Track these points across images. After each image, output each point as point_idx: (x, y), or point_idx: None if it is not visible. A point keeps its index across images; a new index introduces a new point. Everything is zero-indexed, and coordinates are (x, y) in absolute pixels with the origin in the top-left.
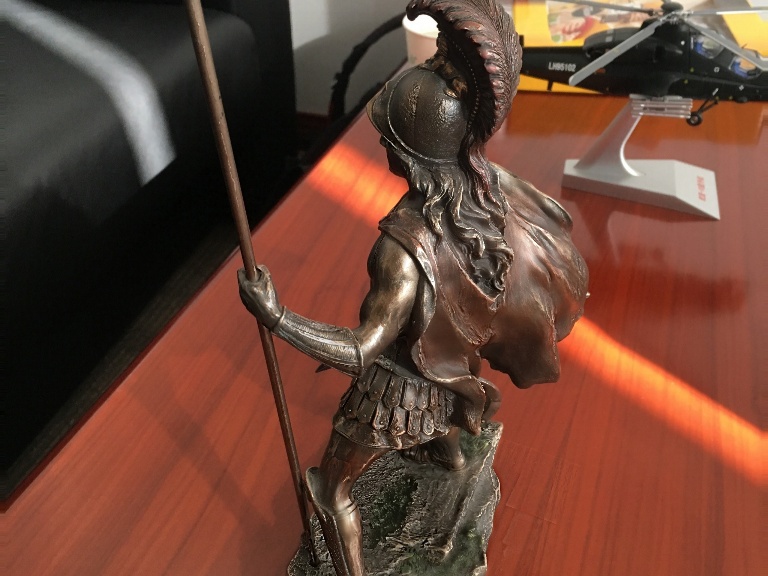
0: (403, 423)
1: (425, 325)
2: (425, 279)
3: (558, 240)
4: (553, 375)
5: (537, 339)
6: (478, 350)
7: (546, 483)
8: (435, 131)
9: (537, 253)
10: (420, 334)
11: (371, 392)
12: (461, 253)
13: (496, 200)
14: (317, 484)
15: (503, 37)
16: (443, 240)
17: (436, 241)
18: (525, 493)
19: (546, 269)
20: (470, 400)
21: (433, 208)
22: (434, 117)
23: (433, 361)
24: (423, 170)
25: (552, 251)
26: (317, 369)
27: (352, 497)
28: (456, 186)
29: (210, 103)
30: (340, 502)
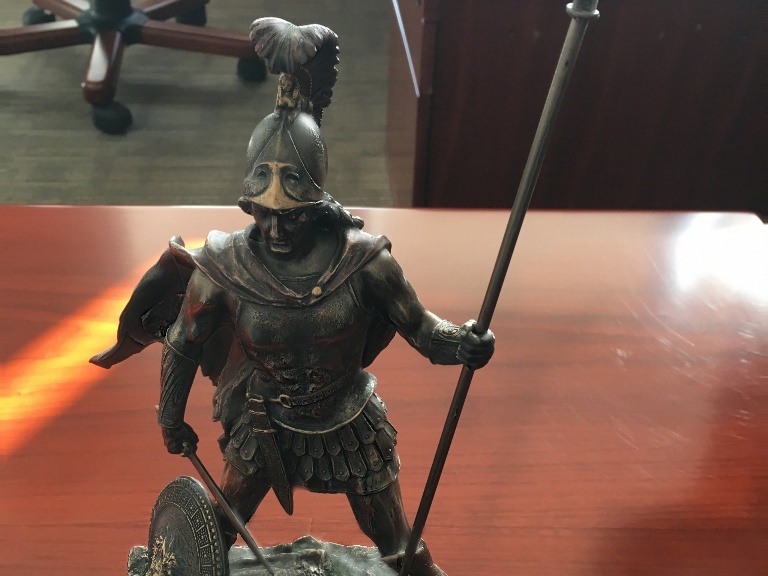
0: None
1: None
2: None
3: None
4: None
5: None
6: None
7: None
8: None
9: None
10: None
11: (384, 415)
12: None
13: None
14: (405, 546)
15: None
16: None
17: None
18: None
19: None
20: None
21: None
22: None
23: None
24: None
25: None
26: (272, 573)
27: None
28: None
29: None
30: None
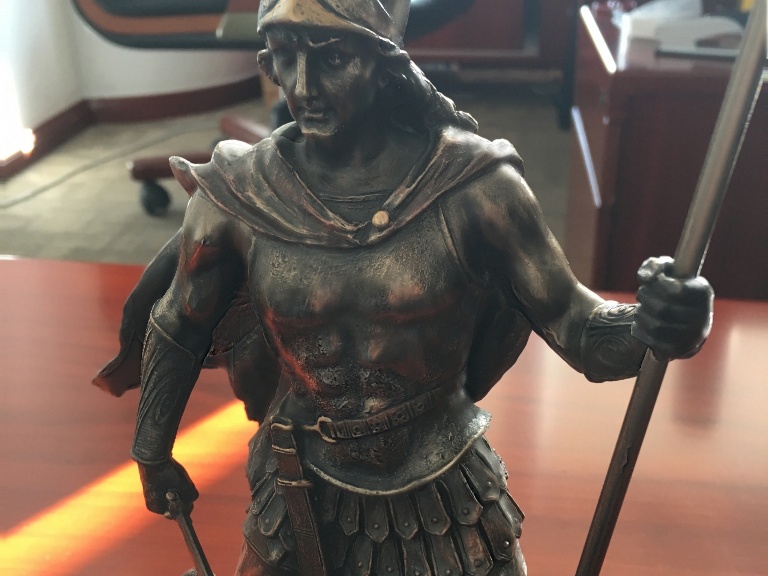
0: None
1: None
2: None
3: None
4: None
5: None
6: None
7: None
8: None
9: None
10: None
11: (500, 480)
12: None
13: None
14: None
15: None
16: None
17: None
18: None
19: None
20: None
21: None
22: None
23: None
24: None
25: None
26: None
27: None
28: None
29: None
30: None
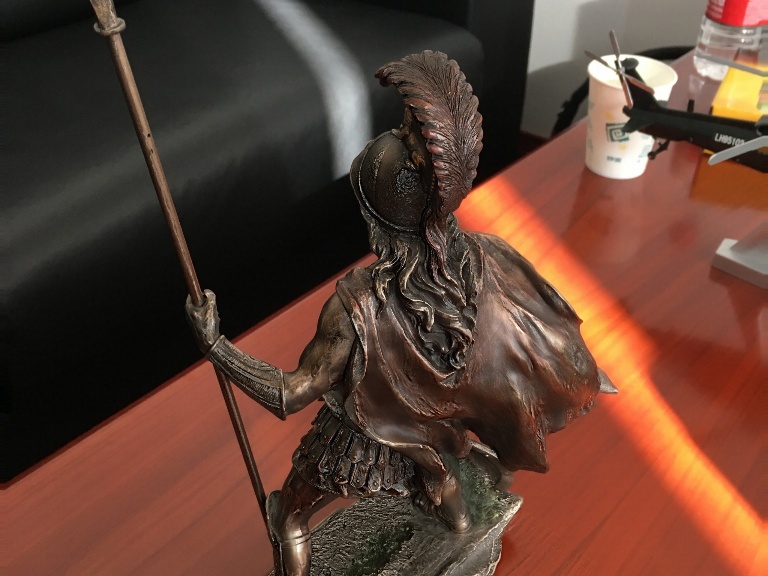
0: (347, 473)
1: (354, 385)
2: (358, 341)
3: (550, 330)
4: (538, 465)
5: (513, 425)
6: (448, 421)
7: (553, 572)
8: (392, 198)
9: (519, 338)
10: (349, 393)
11: (322, 435)
12: (410, 323)
13: (453, 278)
14: (275, 508)
15: (457, 119)
16: (388, 306)
17: (379, 306)
18: (526, 575)
19: (528, 357)
20: (425, 468)
21: (383, 273)
22: (392, 185)
23: (379, 421)
24: (384, 233)
25: (539, 340)
26: None
27: (305, 530)
28: (411, 256)
29: (140, 138)
30: (290, 531)
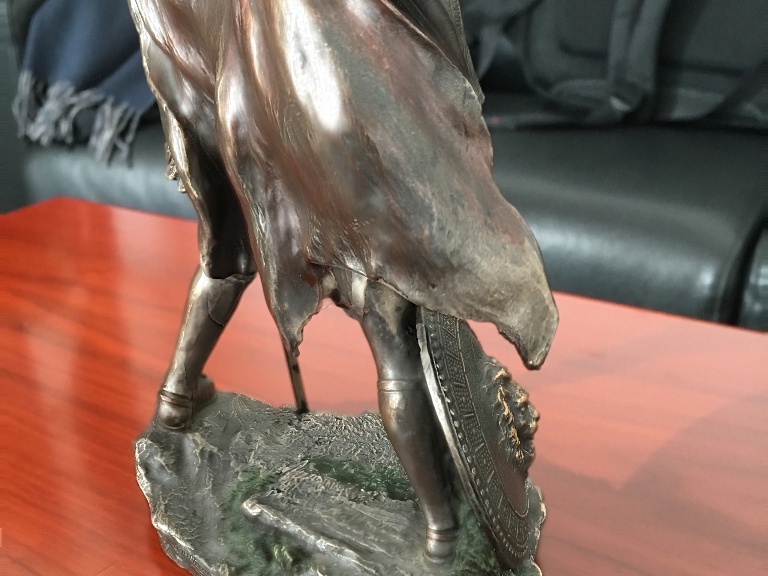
0: None
1: None
2: None
3: None
4: None
5: None
6: None
7: None
8: None
9: None
10: None
11: None
12: None
13: None
14: None
15: None
16: None
17: None
18: None
19: None
20: None
21: None
22: None
23: None
24: None
25: None
26: None
27: None
28: None
29: None
30: None
